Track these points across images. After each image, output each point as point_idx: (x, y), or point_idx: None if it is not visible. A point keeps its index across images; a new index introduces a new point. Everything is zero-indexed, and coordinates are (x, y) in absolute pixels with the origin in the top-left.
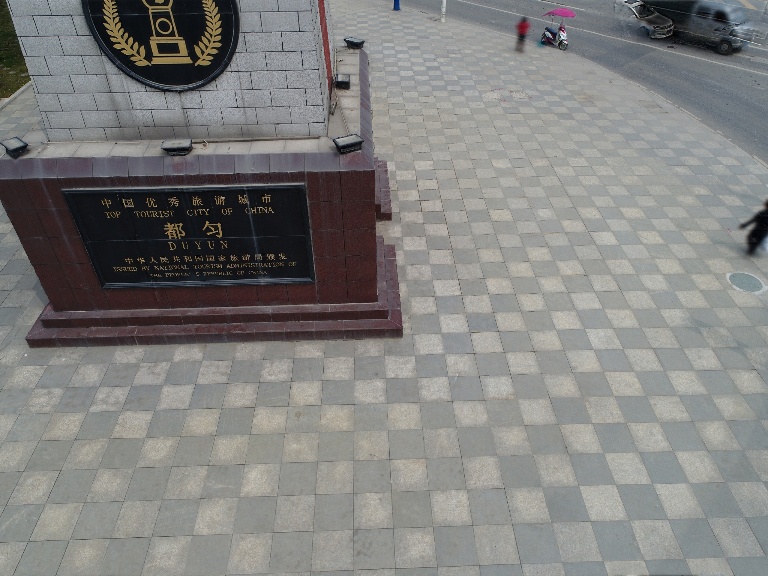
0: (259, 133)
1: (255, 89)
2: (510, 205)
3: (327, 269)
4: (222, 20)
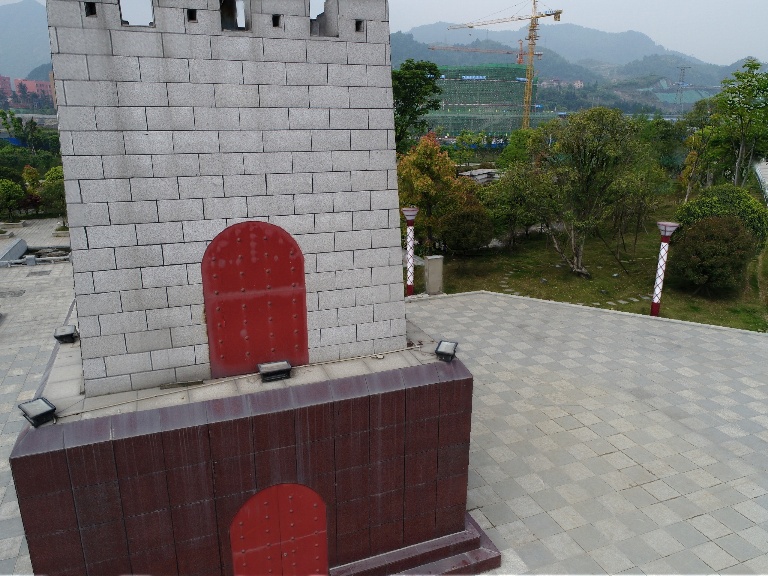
0: None
1: None
2: None
3: None
4: None
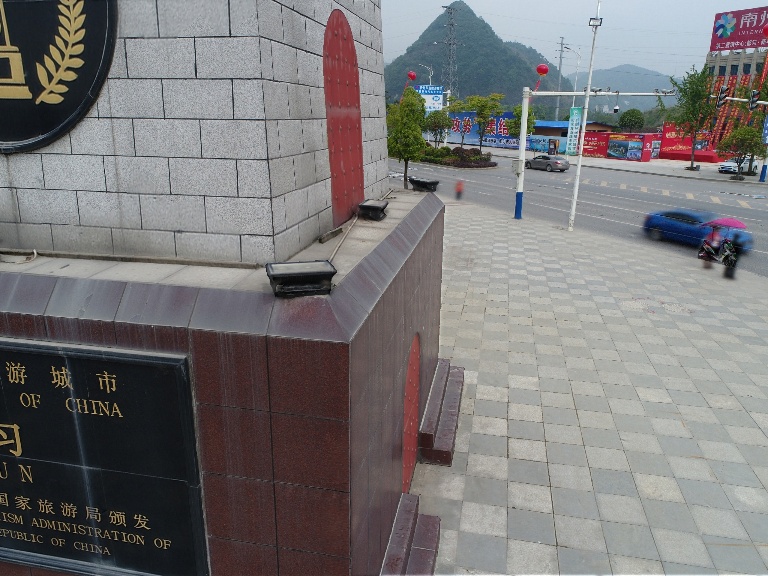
0: (144, 248)
1: (140, 156)
2: (675, 470)
3: (237, 570)
4: (87, 13)
